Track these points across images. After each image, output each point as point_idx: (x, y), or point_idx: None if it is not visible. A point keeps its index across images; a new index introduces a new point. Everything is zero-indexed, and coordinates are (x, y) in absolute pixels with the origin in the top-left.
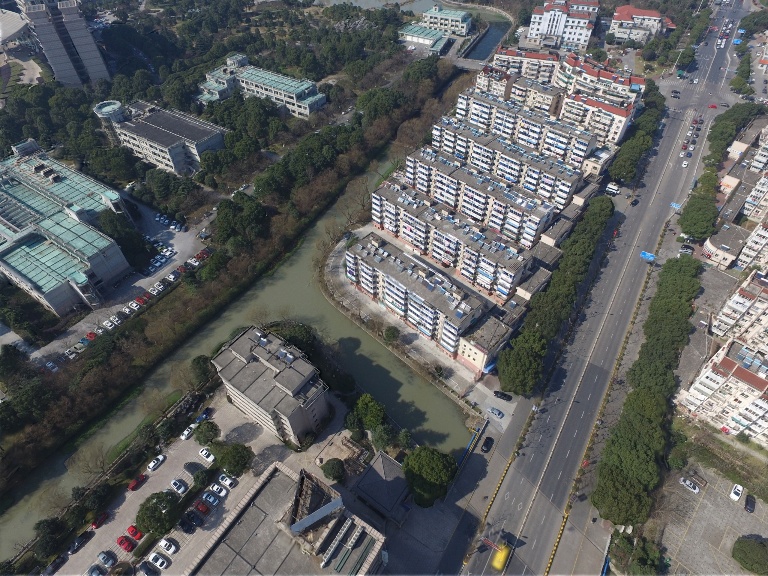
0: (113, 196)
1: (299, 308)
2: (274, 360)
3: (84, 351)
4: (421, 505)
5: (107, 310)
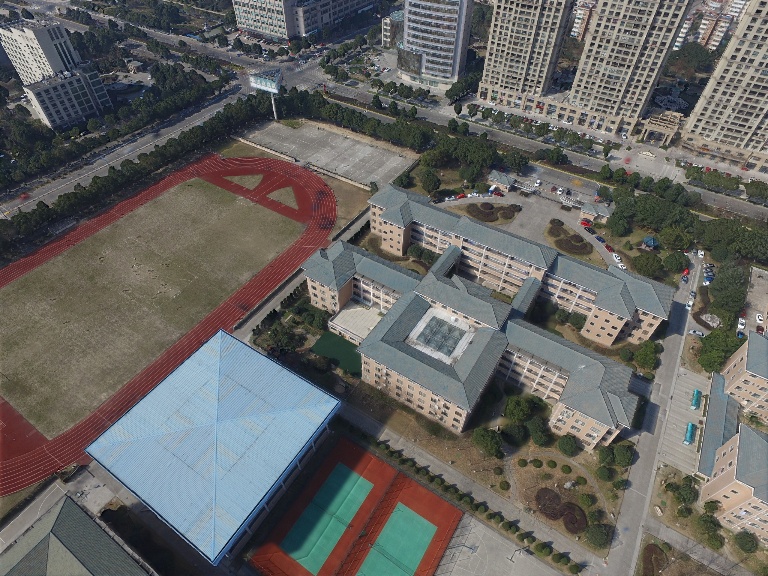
0: None
1: None
2: None
3: None
4: (388, 0)
5: None
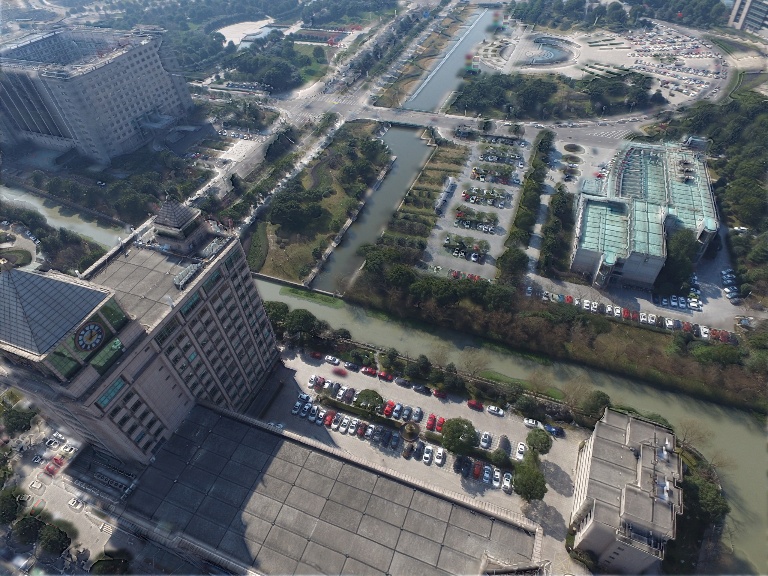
0: (712, 226)
1: (741, 475)
2: (649, 474)
3: (554, 303)
4: None
5: (599, 295)
